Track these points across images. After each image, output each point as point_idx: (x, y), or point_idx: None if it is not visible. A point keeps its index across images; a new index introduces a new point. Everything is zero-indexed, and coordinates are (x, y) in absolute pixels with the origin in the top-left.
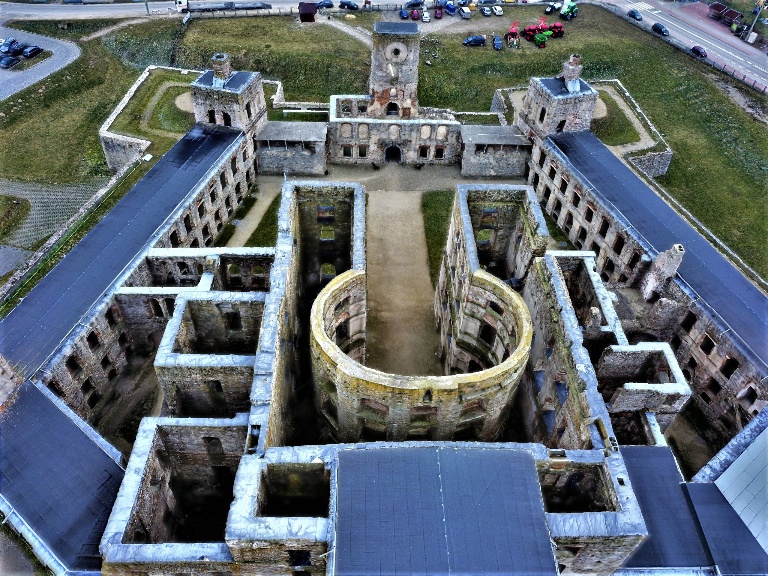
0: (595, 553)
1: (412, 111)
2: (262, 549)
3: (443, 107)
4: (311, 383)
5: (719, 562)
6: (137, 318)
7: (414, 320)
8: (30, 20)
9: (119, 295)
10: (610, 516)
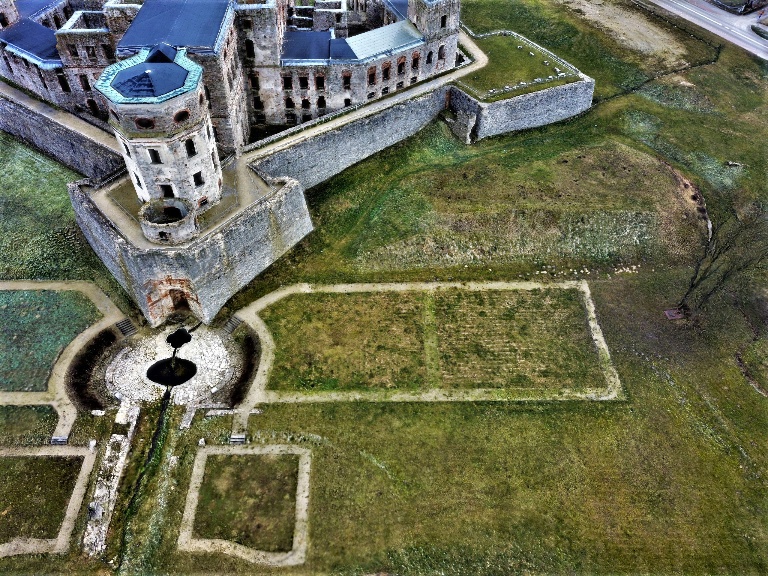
0: (259, 27)
1: None
2: (118, 18)
3: None
4: None
5: (332, 56)
6: None
7: None
8: None
9: (70, 0)
10: (260, 4)
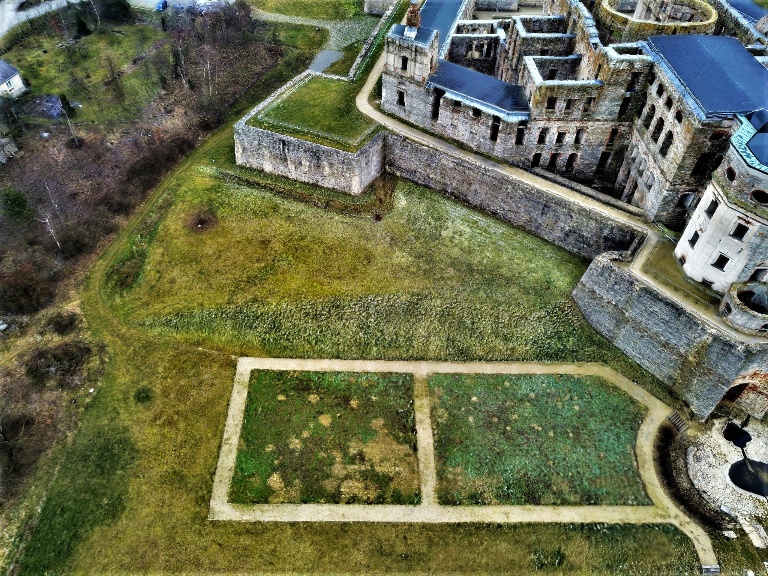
0: None
1: None
2: (623, 71)
3: None
4: None
5: None
6: (457, 57)
7: None
8: None
9: (454, 37)
10: None
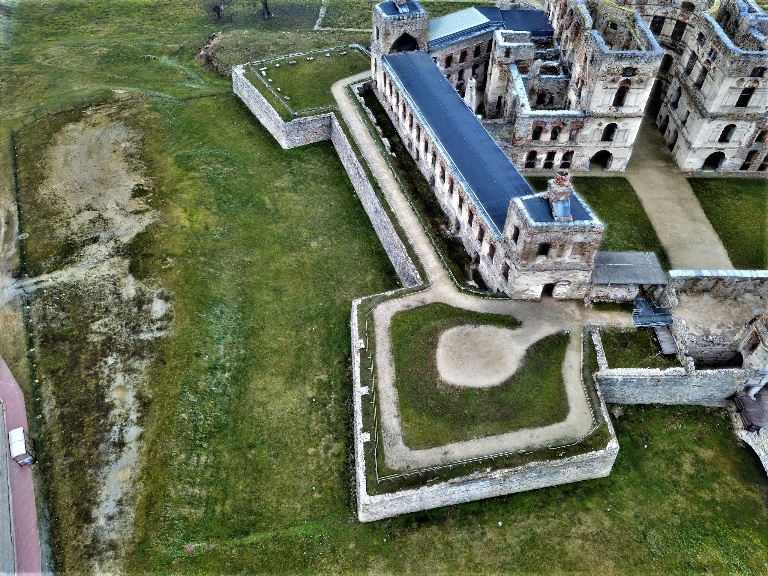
0: None
1: None
2: None
3: (701, 508)
4: None
5: (497, 8)
6: None
7: (637, 160)
8: None
9: None
10: None
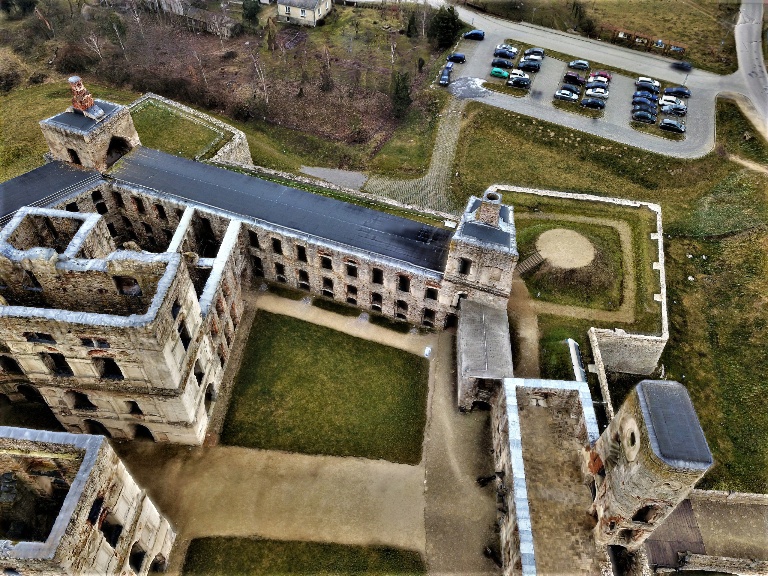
0: None
1: (597, 527)
2: None
3: None
4: (59, 362)
5: None
6: None
7: (155, 502)
8: (741, 111)
9: None
10: None
